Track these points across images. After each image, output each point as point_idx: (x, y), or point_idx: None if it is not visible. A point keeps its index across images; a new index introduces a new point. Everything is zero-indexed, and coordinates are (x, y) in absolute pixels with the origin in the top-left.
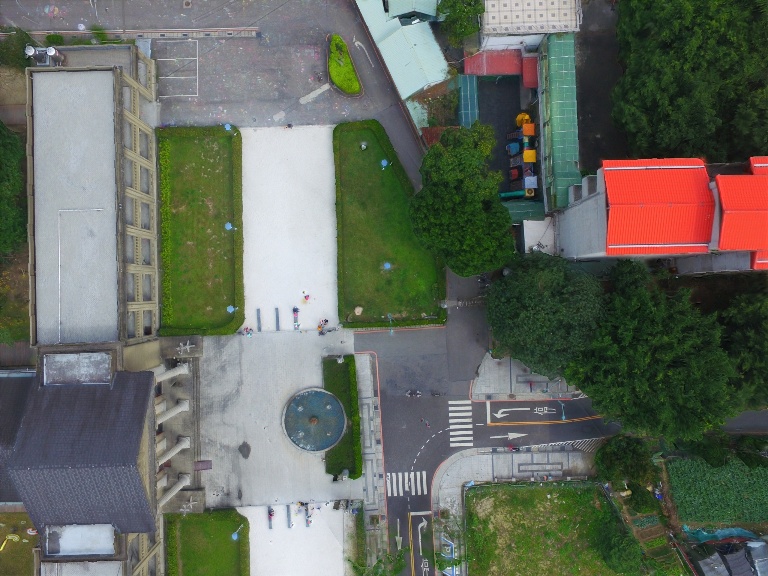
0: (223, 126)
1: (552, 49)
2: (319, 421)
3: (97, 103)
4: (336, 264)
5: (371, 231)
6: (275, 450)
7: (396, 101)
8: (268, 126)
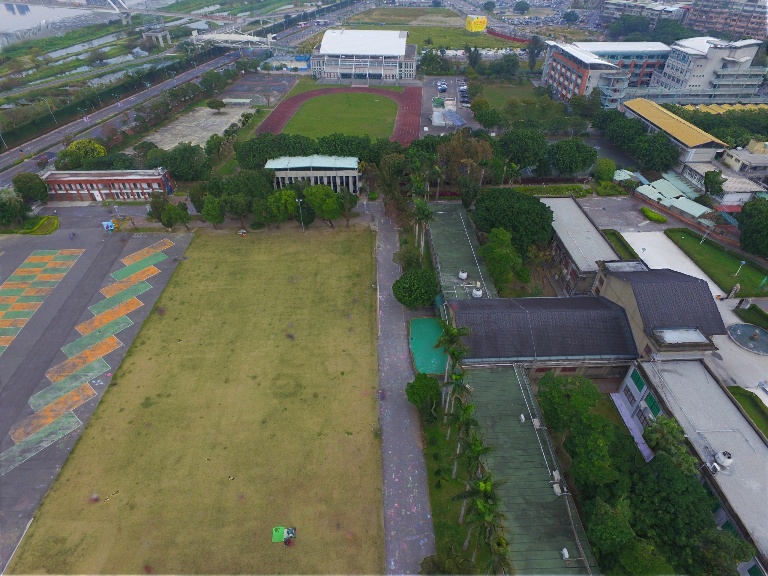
0: (608, 229)
1: (760, 196)
2: (757, 339)
3: (568, 205)
4: (705, 274)
5: (713, 263)
6: (739, 355)
7: (687, 225)
8: (628, 232)
